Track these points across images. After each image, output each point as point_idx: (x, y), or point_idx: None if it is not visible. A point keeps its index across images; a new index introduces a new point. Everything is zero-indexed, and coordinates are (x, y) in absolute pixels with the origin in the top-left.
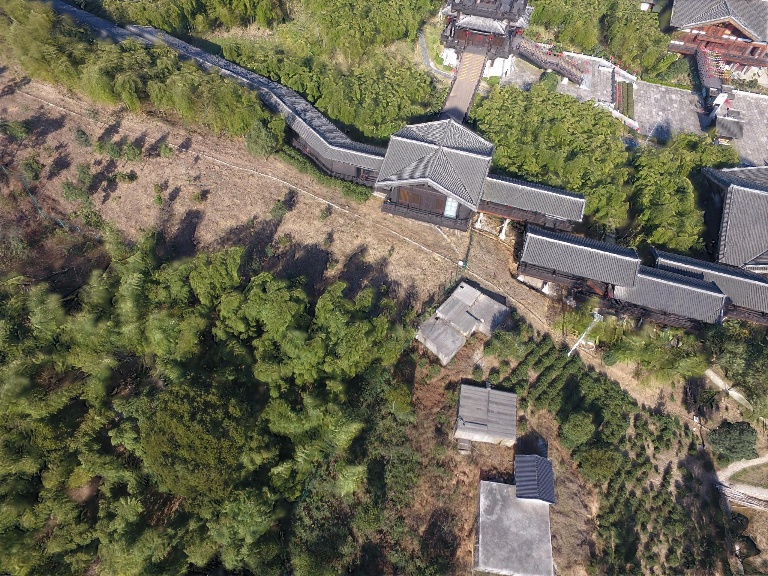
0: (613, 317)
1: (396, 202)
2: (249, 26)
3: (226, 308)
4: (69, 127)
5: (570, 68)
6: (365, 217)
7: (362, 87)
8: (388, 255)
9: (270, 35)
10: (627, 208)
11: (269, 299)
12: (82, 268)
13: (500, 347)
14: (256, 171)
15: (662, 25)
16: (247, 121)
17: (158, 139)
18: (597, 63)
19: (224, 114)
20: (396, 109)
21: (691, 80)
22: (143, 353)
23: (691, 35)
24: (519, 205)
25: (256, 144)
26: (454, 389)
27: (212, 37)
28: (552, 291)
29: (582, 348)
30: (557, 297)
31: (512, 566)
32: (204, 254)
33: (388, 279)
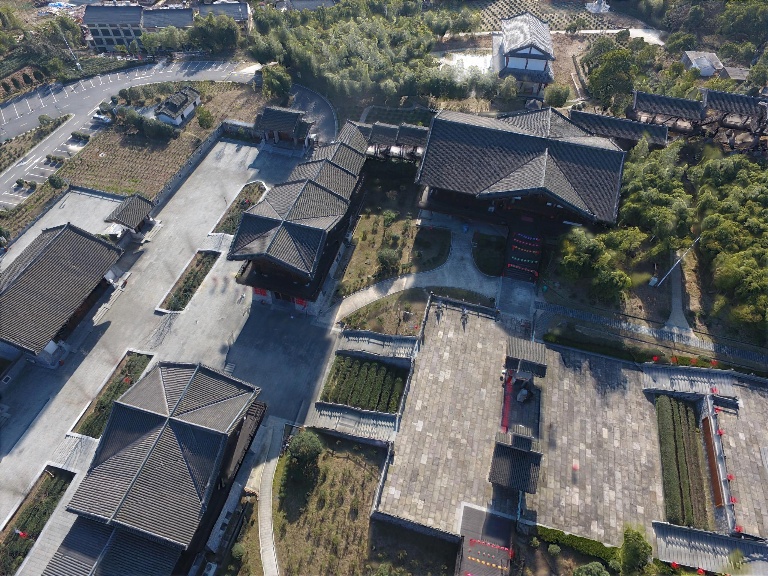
0: (668, 135)
1: None
2: None
3: None
4: None
5: None
6: None
7: None
8: None
9: None
10: None
11: None
12: None
13: None
14: None
15: None
16: None
17: None
18: None
19: None
20: None
21: None
22: None
23: None
24: None
25: None
26: (763, 82)
27: None
28: None
29: None
30: None
31: (702, 53)
32: None
33: None
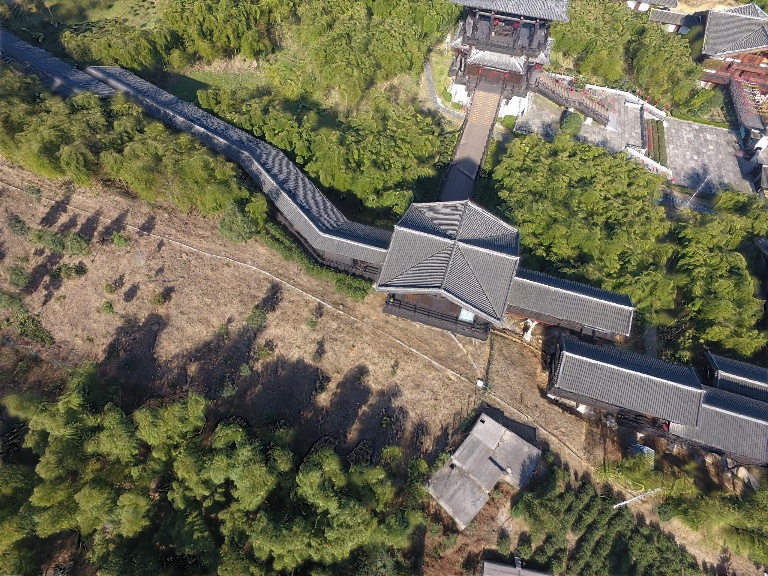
0: (662, 440)
1: (401, 301)
2: (234, 58)
3: (185, 471)
4: (6, 206)
5: (594, 106)
6: (363, 320)
7: (360, 146)
8: (391, 373)
9: (257, 68)
10: (674, 297)
11: (239, 461)
12: (7, 406)
13: (535, 523)
14: (232, 259)
15: (691, 50)
16: (221, 200)
17: (114, 219)
18: (623, 98)
19: (193, 192)
20: (400, 172)
21: (725, 115)
22: (78, 529)
23: (724, 63)
24: (552, 312)
25: (231, 231)
26: (475, 567)
27: (191, 72)
28: (589, 409)
29: (628, 490)
30: (595, 416)
31: None
32: (157, 399)
33: (391, 404)
